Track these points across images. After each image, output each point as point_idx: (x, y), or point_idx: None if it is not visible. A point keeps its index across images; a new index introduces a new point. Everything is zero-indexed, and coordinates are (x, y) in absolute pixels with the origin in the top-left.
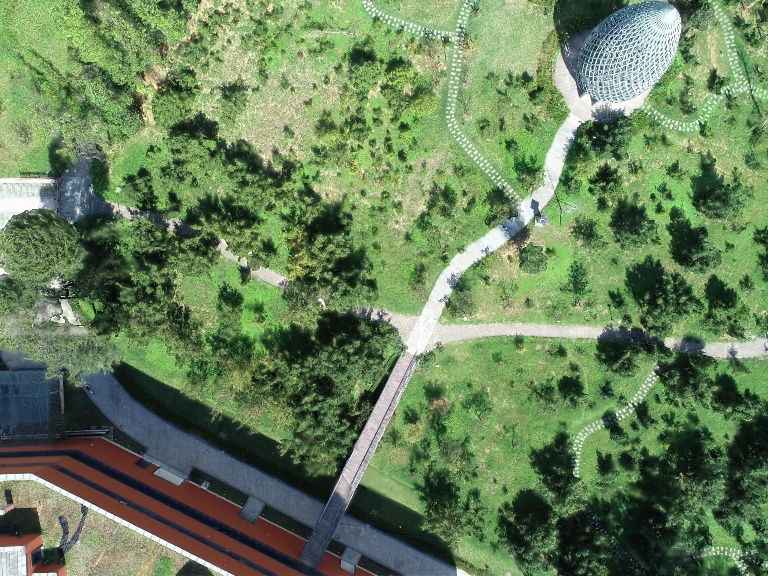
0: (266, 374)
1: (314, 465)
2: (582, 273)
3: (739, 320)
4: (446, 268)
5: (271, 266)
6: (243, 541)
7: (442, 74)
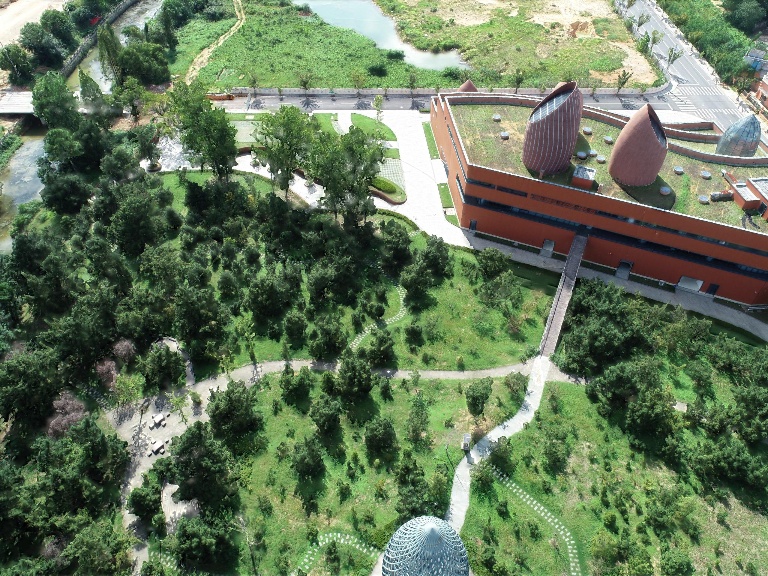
0: None
1: (597, 284)
2: None
3: None
4: None
5: None
6: (629, 243)
7: None
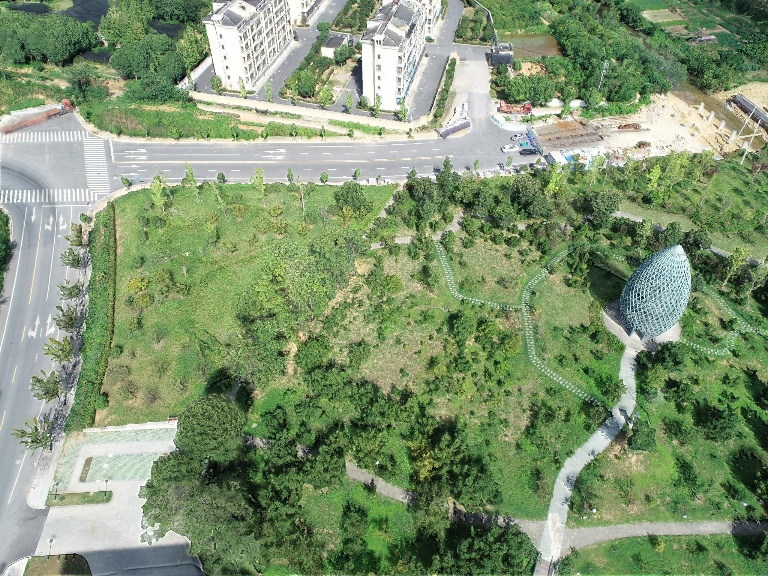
0: None
1: None
2: (688, 466)
3: None
4: (560, 472)
5: (394, 482)
6: None
7: (519, 329)
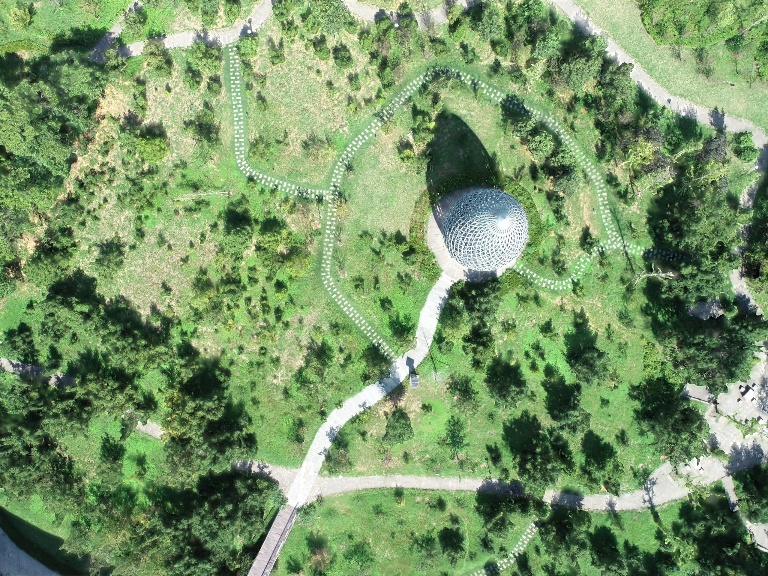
0: (147, 528)
1: None
2: (458, 429)
3: (613, 477)
4: (325, 422)
5: (152, 419)
6: None
7: (316, 232)
